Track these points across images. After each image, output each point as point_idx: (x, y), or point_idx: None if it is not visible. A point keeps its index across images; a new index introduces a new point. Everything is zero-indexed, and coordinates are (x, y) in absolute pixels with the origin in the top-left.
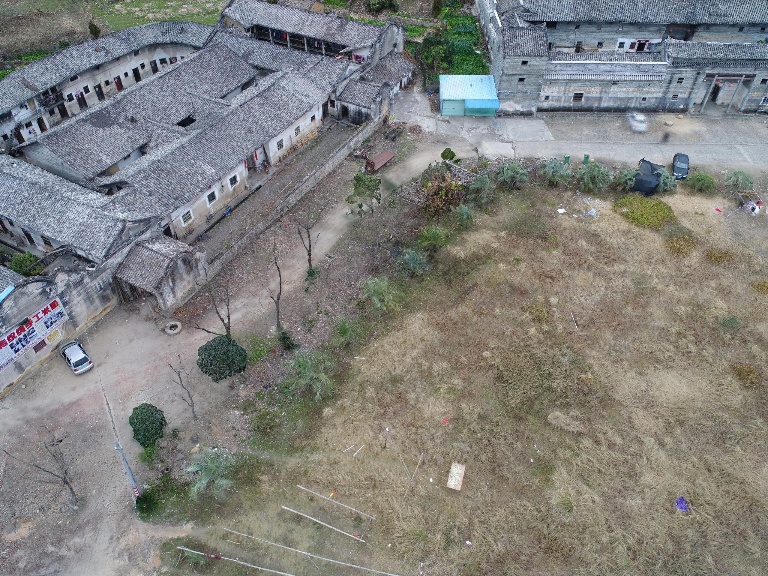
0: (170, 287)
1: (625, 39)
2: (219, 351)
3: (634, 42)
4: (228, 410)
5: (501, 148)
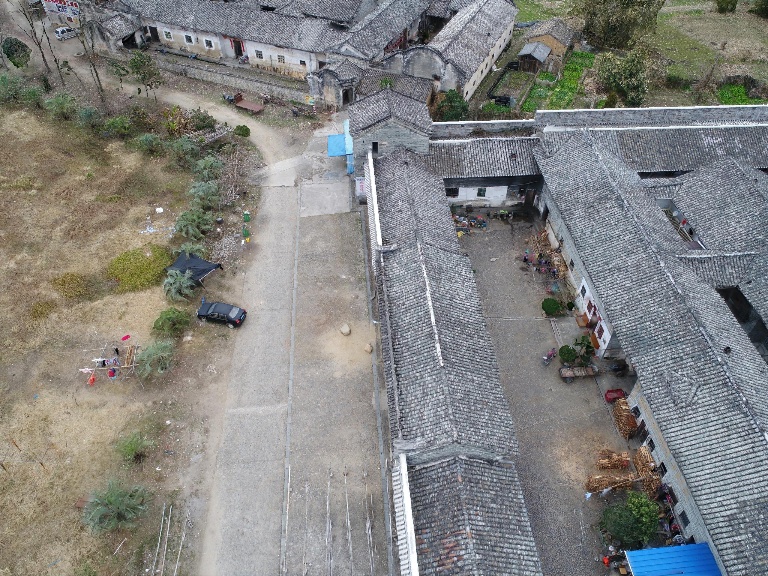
0: (90, 35)
1: (588, 286)
2: (5, 40)
3: (592, 303)
4: (8, 77)
5: (282, 177)
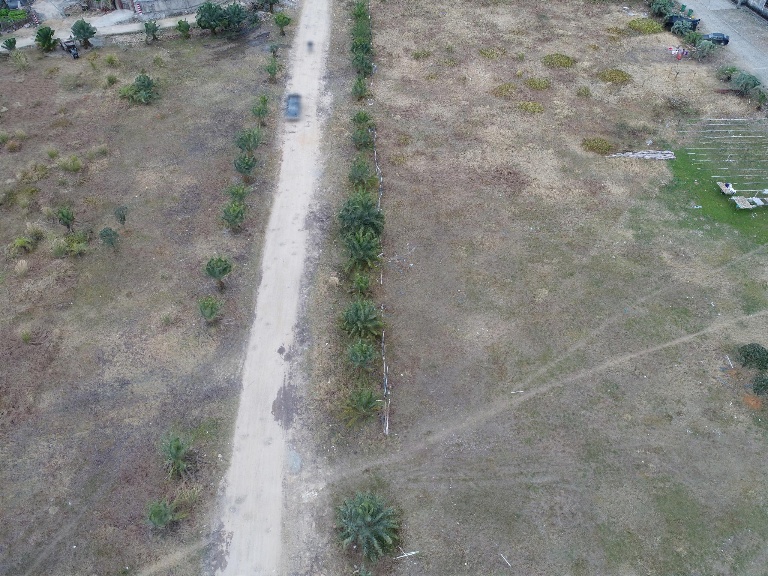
0: None
1: None
2: None
3: None
4: None
5: None
